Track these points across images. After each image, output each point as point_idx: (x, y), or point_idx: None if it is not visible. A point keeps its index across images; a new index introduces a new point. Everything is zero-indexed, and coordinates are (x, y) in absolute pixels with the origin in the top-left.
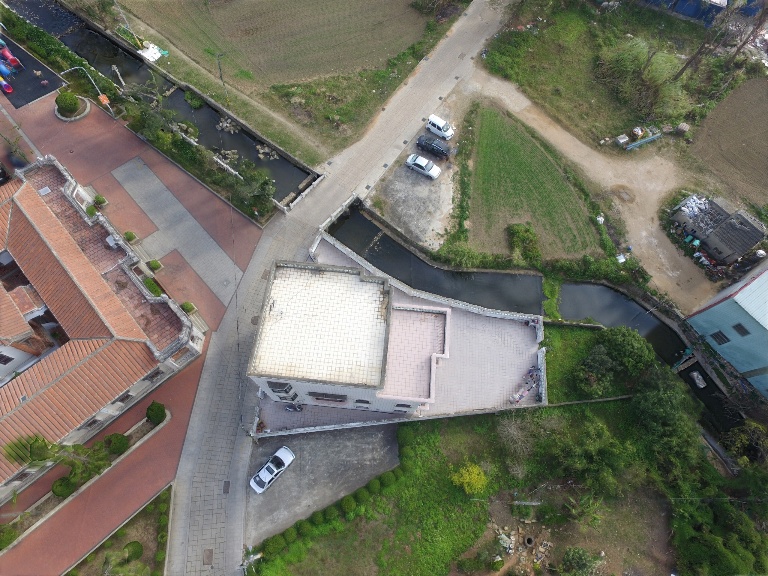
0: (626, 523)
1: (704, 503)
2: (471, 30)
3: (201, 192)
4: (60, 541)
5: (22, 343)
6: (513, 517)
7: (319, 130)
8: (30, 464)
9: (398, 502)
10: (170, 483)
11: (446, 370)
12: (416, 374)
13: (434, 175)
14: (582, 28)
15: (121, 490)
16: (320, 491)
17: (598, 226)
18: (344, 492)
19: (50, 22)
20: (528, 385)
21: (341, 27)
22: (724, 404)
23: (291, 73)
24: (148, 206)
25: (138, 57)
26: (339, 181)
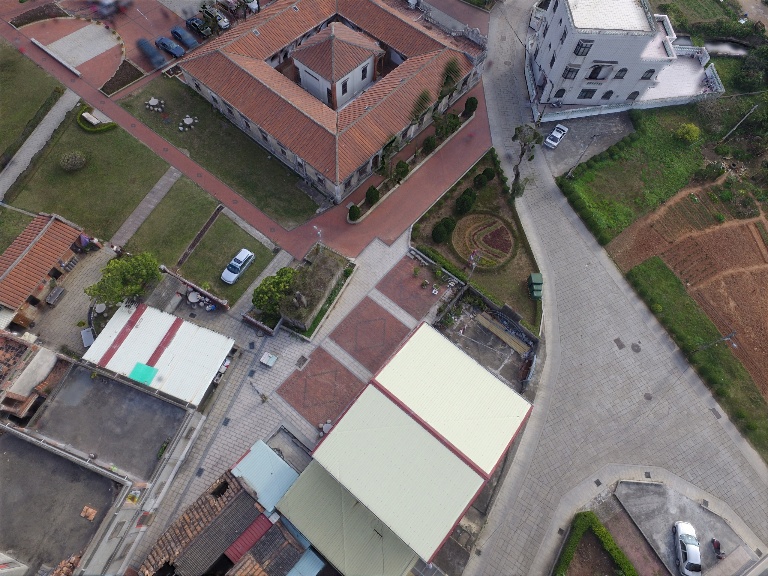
0: None
1: None
2: None
3: None
4: (434, 177)
5: None
6: (718, 156)
7: None
8: None
9: (643, 150)
10: (492, 146)
11: None
12: (656, 50)
13: None
14: None
15: (460, 152)
16: (590, 148)
17: (721, 3)
18: (606, 147)
19: None
20: (705, 88)
21: None
22: None
23: None
24: None
25: None
26: None
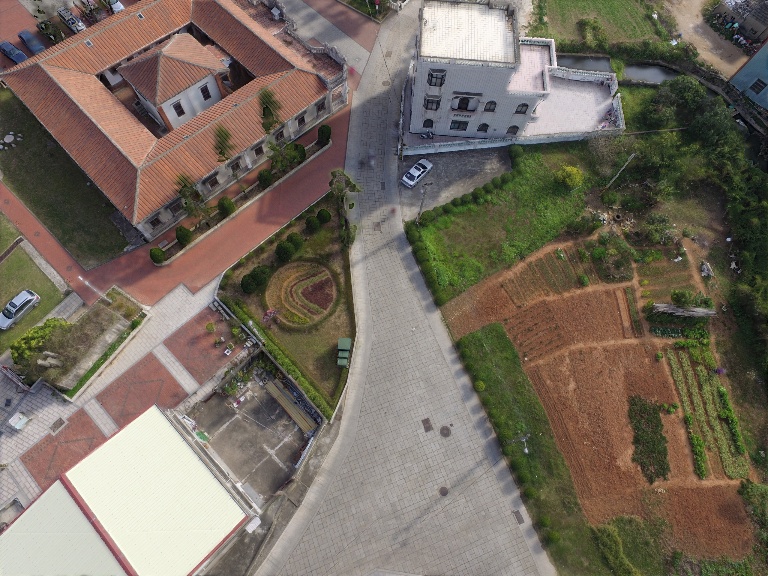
0: (690, 209)
1: (751, 189)
2: None
3: None
4: (266, 216)
5: (221, 79)
6: (604, 204)
7: None
8: (244, 153)
9: (515, 194)
10: None
11: (541, 114)
12: (532, 82)
13: None
14: None
15: (304, 187)
16: (455, 188)
17: (653, 20)
18: (473, 189)
19: None
20: (607, 122)
21: None
22: (761, 140)
23: None
24: None
25: None
26: None
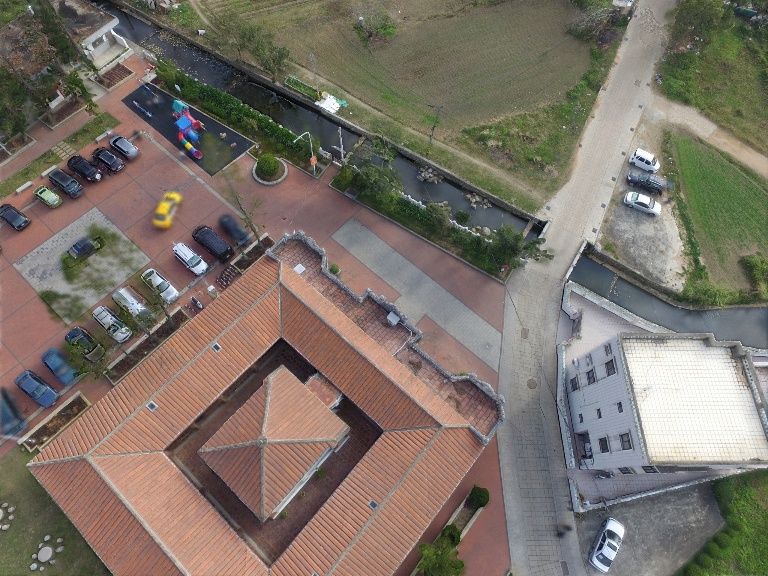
0: None
1: None
2: (637, 55)
3: (429, 250)
4: None
5: None
6: None
7: (526, 173)
8: None
9: (738, 564)
10: (510, 571)
11: None
12: None
13: (658, 212)
14: (739, 45)
15: None
16: (658, 561)
17: None
18: (681, 559)
19: (211, 77)
20: None
21: (508, 61)
22: None
23: (477, 114)
24: (382, 271)
25: (313, 108)
26: (565, 226)
